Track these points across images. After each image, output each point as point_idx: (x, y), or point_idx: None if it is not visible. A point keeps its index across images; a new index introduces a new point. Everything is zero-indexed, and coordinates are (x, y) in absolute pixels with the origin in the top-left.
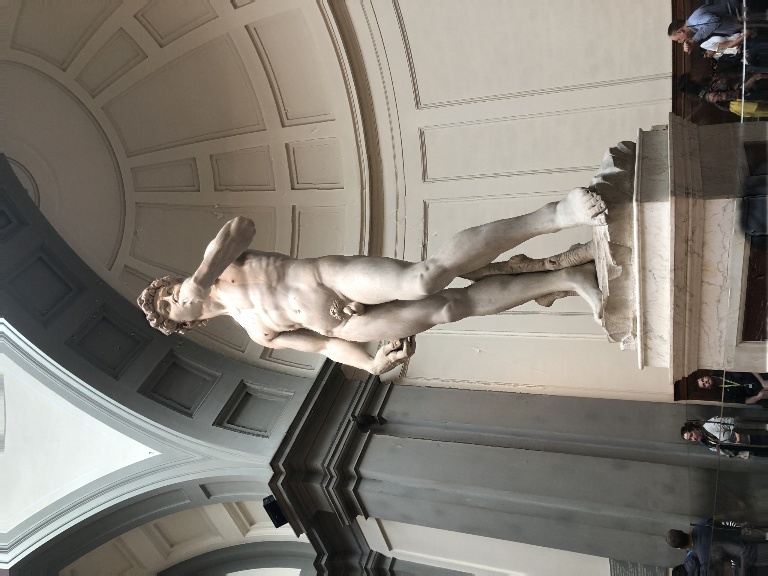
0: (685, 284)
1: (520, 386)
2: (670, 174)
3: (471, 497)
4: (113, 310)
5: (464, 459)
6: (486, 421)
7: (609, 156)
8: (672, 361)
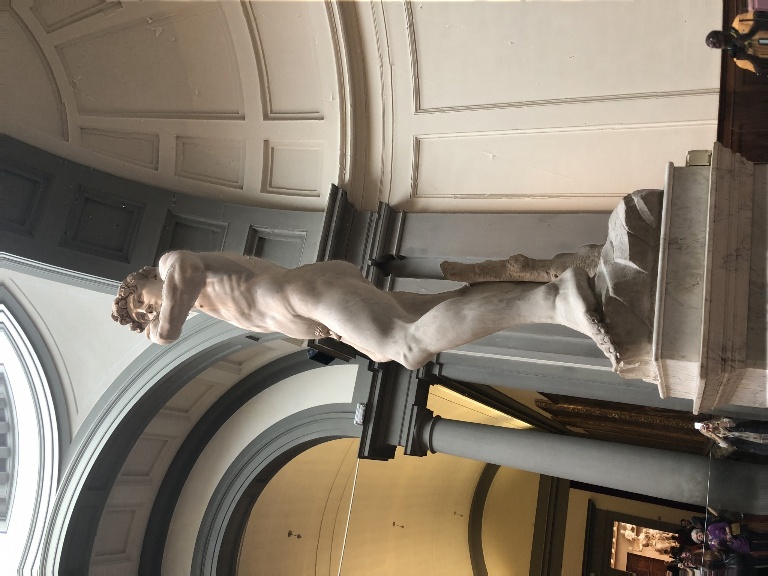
0: None
1: (541, 198)
2: (704, 311)
3: (500, 337)
4: (92, 189)
5: None
6: (507, 253)
7: (623, 230)
8: None
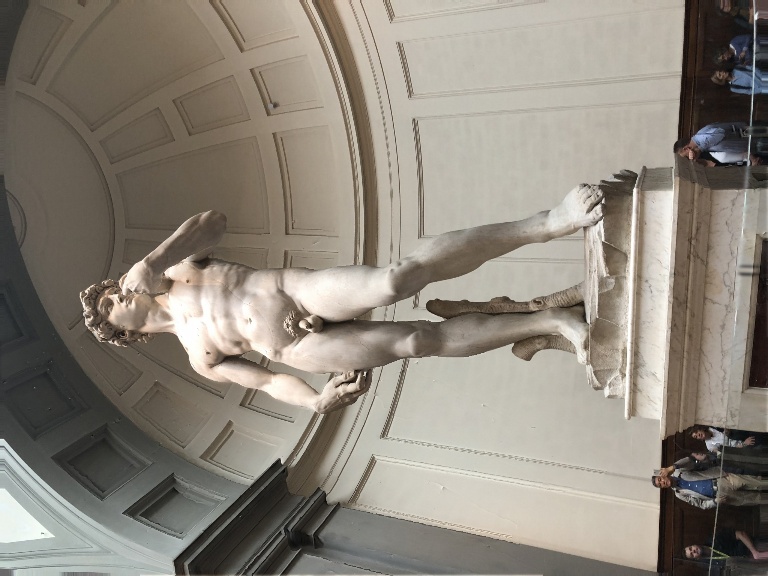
0: (685, 298)
1: (483, 532)
2: (674, 174)
3: None
4: (58, 368)
5: None
6: (438, 559)
7: None
8: (665, 405)
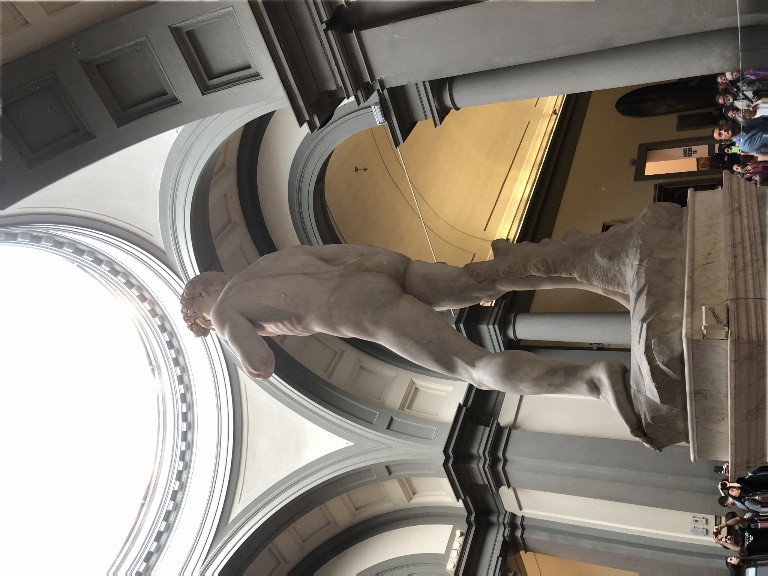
0: None
1: None
2: None
3: (499, 56)
4: None
5: (474, 27)
6: None
7: None
8: None
